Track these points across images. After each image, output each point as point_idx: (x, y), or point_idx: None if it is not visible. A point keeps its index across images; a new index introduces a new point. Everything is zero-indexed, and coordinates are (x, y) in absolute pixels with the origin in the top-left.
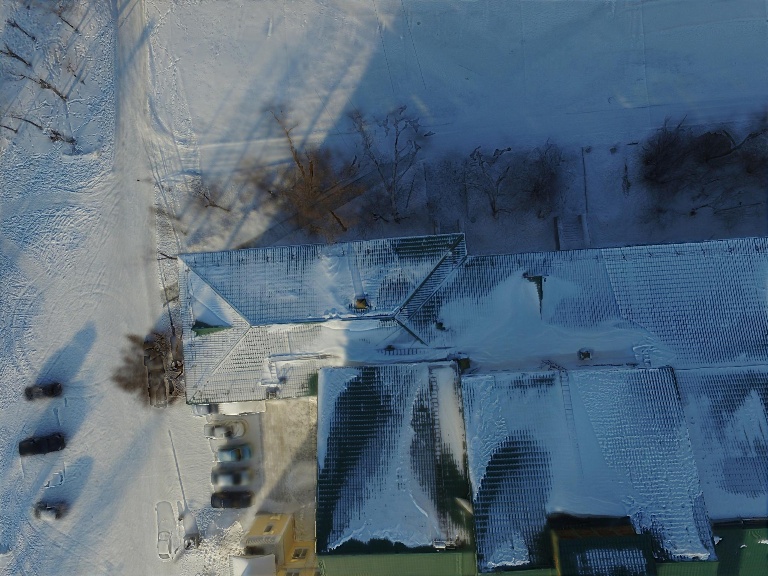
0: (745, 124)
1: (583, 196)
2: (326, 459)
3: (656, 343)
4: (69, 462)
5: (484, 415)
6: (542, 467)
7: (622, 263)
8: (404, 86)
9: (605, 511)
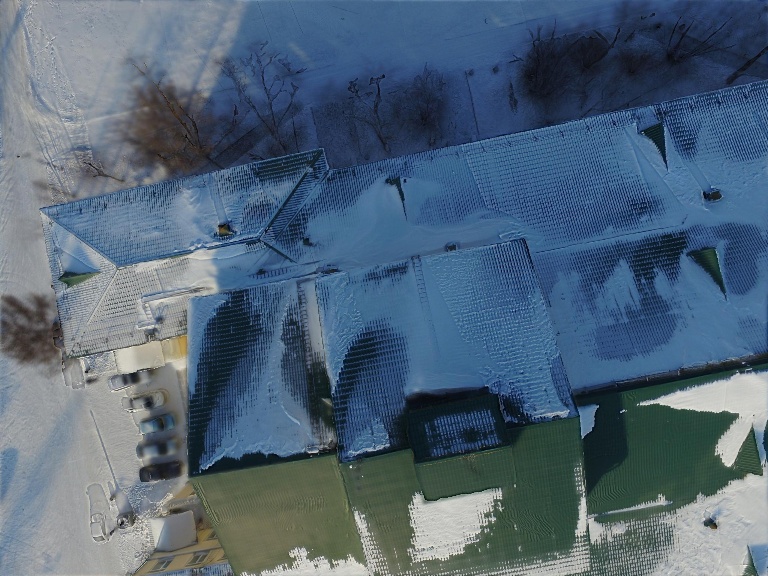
0: (621, 26)
1: (473, 119)
2: (196, 384)
3: (523, 228)
4: None
5: (339, 311)
6: (399, 352)
7: (483, 156)
8: (281, 34)
9: (461, 384)
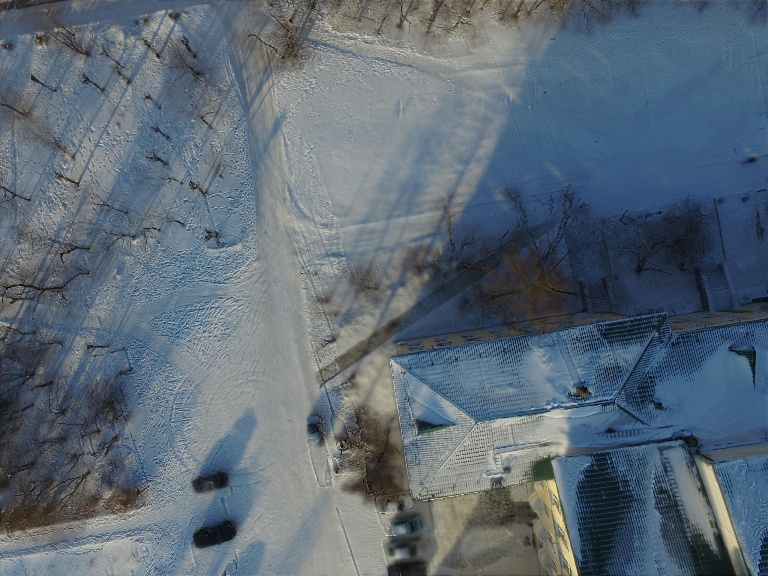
0: None
1: (720, 245)
2: (582, 550)
3: None
4: (240, 549)
5: (745, 500)
6: None
7: None
8: (537, 154)
9: None
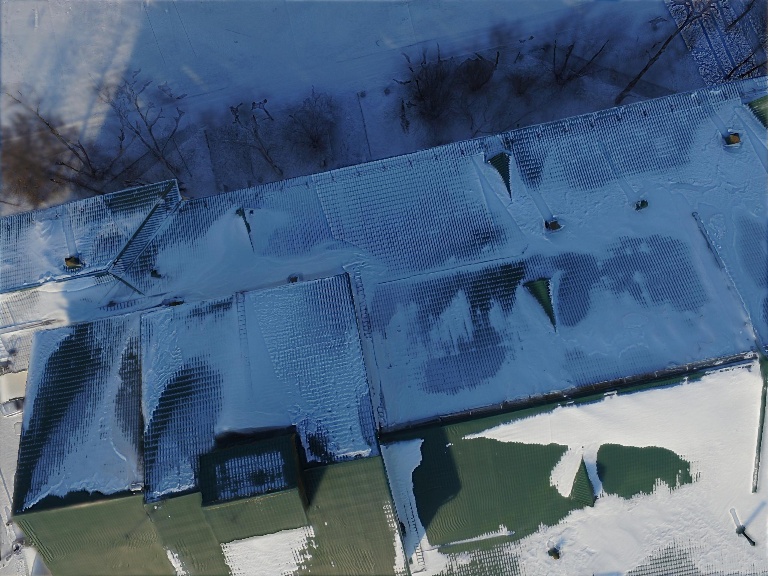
0: (511, 47)
1: (365, 141)
2: (31, 420)
3: (368, 259)
4: None
5: (160, 348)
6: (214, 390)
7: (332, 186)
8: (175, 58)
9: (268, 423)
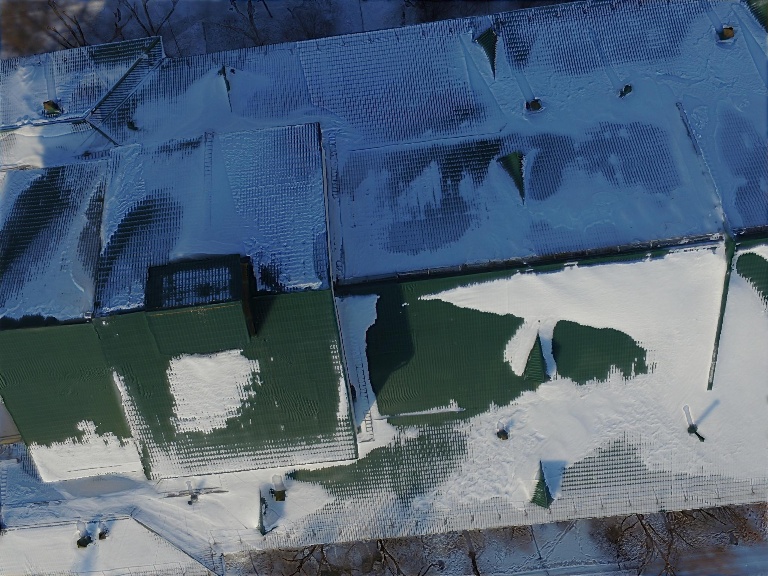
0: None
1: None
2: None
3: (344, 126)
4: None
5: (125, 178)
6: (173, 220)
7: (316, 54)
8: None
9: (223, 251)
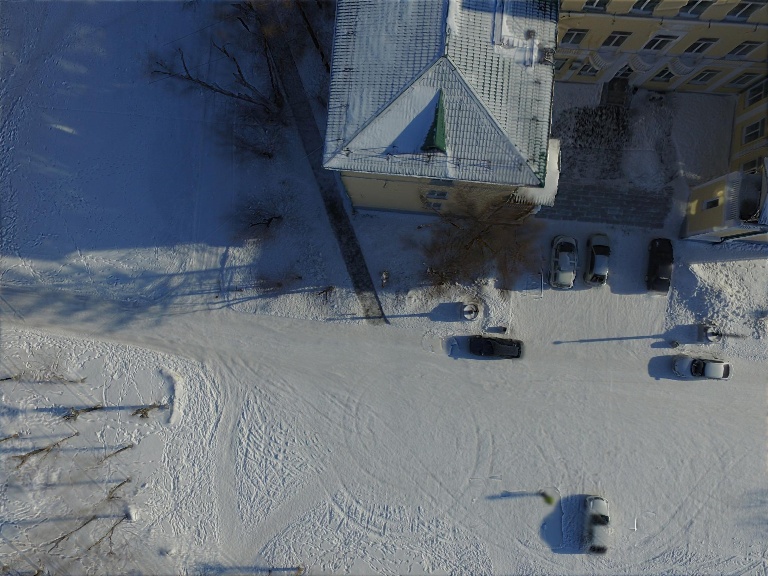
0: None
1: None
2: None
3: None
4: (577, 487)
5: None
6: None
7: None
8: None
9: None
